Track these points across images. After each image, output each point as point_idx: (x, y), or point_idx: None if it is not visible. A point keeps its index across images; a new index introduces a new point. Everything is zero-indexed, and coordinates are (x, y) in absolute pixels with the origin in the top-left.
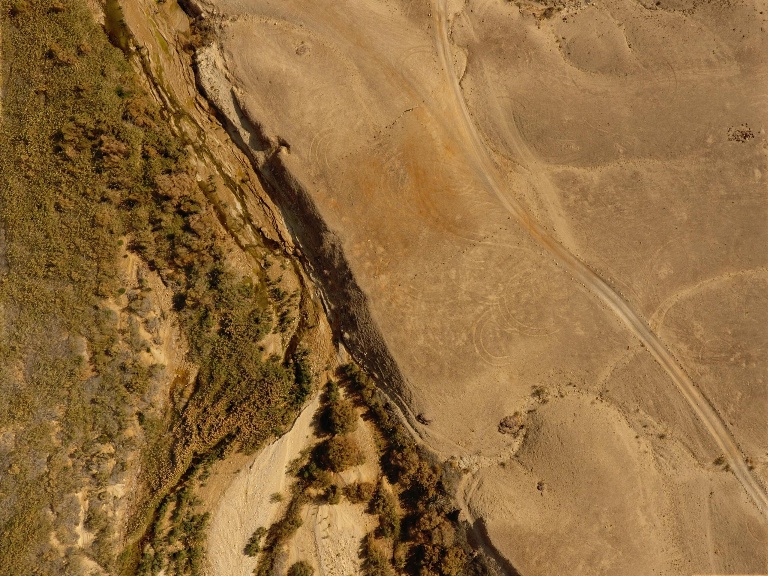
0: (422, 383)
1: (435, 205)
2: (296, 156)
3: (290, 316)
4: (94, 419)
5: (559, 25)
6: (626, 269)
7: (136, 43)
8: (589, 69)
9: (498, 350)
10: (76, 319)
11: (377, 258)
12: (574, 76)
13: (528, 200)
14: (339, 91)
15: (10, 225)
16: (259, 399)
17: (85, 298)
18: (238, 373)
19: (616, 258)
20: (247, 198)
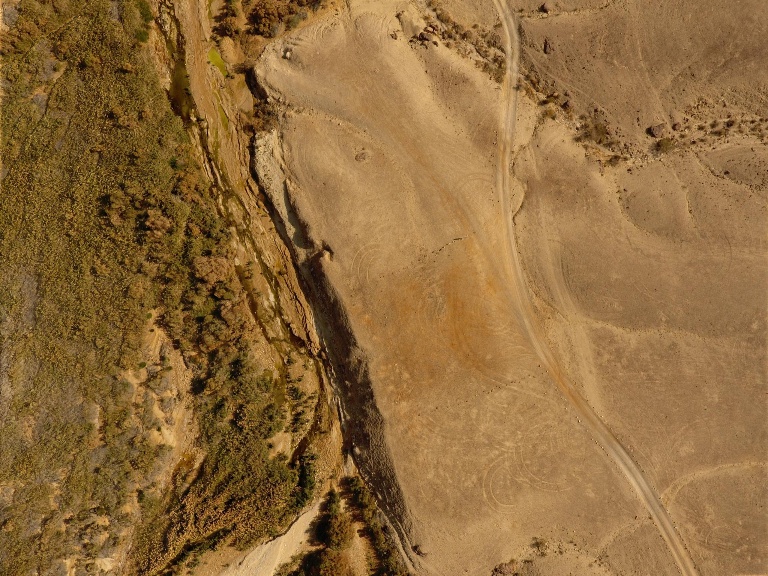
0: (425, 517)
1: (468, 340)
2: (338, 265)
3: (304, 417)
4: (94, 489)
5: (623, 175)
6: (648, 440)
7: (197, 114)
8: (645, 228)
9: (506, 498)
10: (93, 387)
11: (401, 383)
12: (629, 232)
13: (561, 351)
14: (392, 206)
15: (43, 281)
16: (260, 499)
17: (105, 367)
18: (243, 468)
19: (640, 427)
20: (281, 291)
